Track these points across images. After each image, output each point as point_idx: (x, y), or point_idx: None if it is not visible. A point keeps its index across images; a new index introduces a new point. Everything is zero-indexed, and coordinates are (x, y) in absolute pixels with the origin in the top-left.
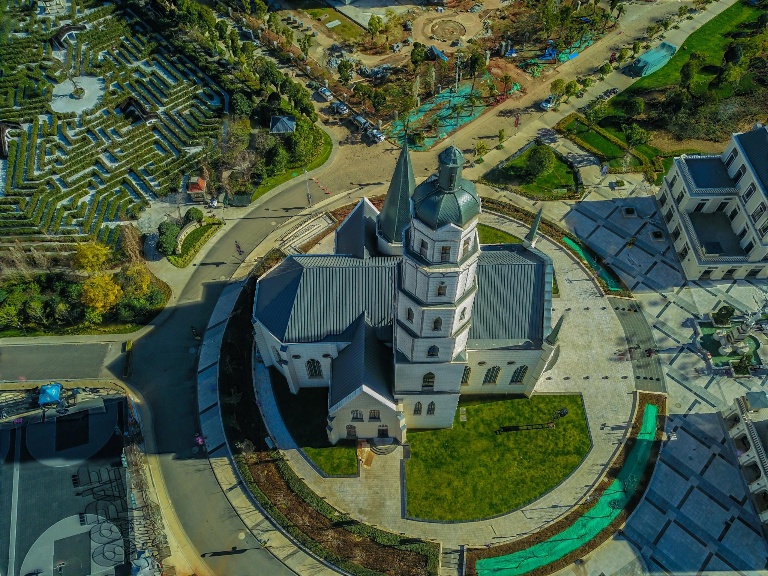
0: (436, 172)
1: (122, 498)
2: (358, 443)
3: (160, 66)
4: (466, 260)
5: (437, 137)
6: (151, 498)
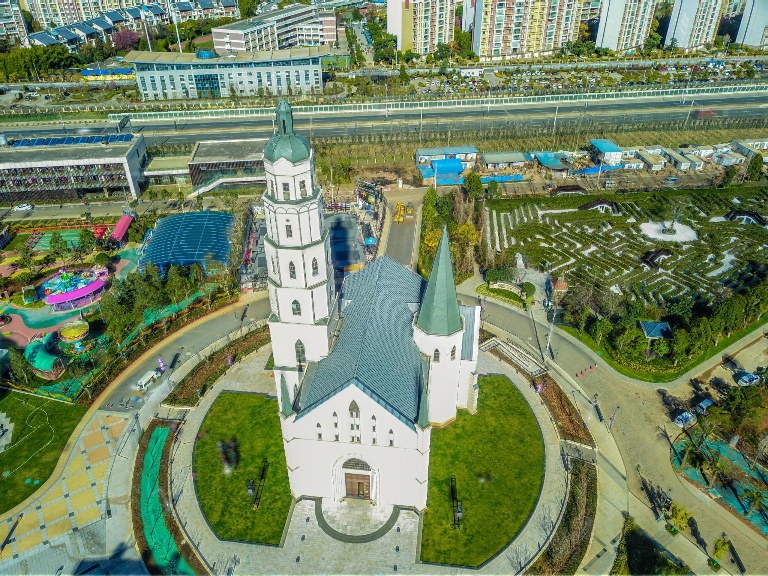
0: (636, 476)
1: None
2: None
3: None
4: (269, 199)
5: (708, 485)
6: None
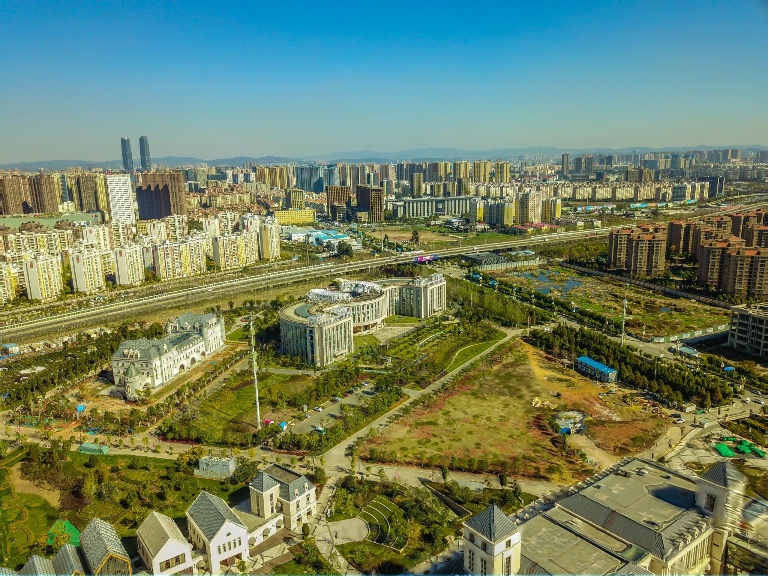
0: None
1: None
2: None
3: None
4: None
5: (15, 424)
6: None
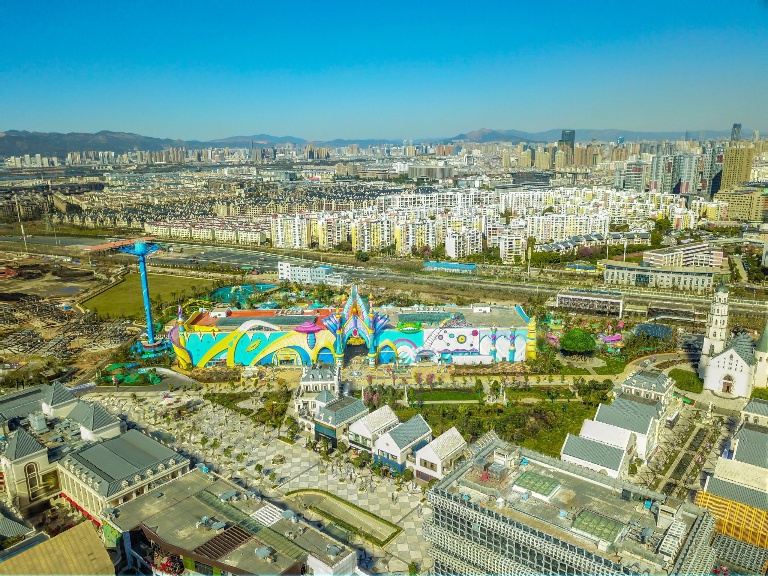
0: None
1: None
2: None
3: None
4: None
5: None
6: None
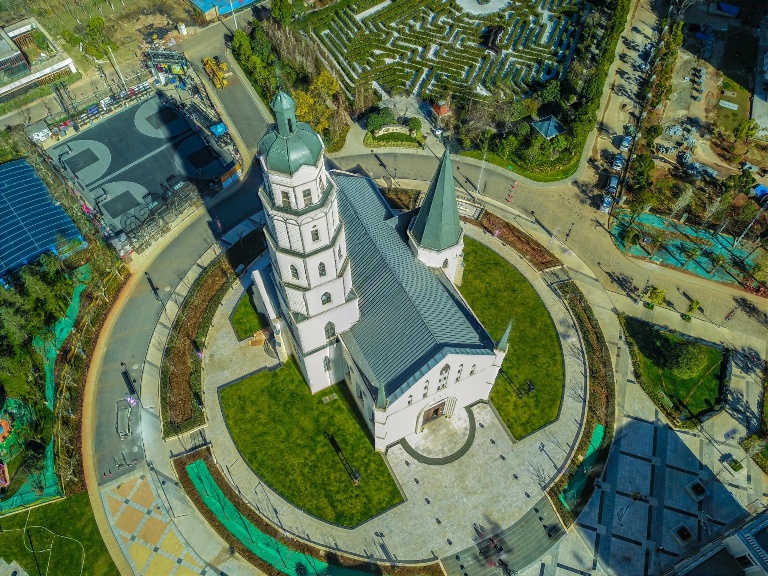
0: (602, 273)
1: None
2: (266, 328)
3: (556, 25)
4: (282, 212)
5: (650, 255)
6: (174, 223)
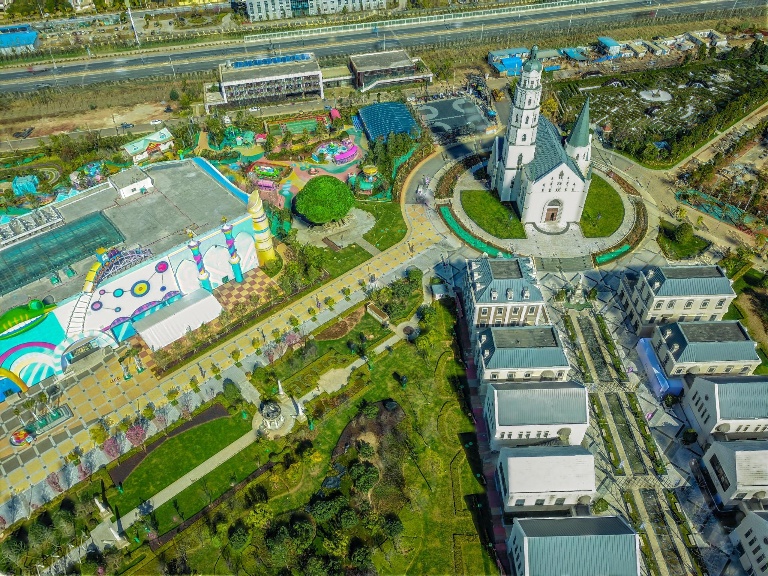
0: (661, 205)
1: (458, 135)
2: None
3: None
4: (522, 88)
5: (692, 205)
6: (459, 140)
